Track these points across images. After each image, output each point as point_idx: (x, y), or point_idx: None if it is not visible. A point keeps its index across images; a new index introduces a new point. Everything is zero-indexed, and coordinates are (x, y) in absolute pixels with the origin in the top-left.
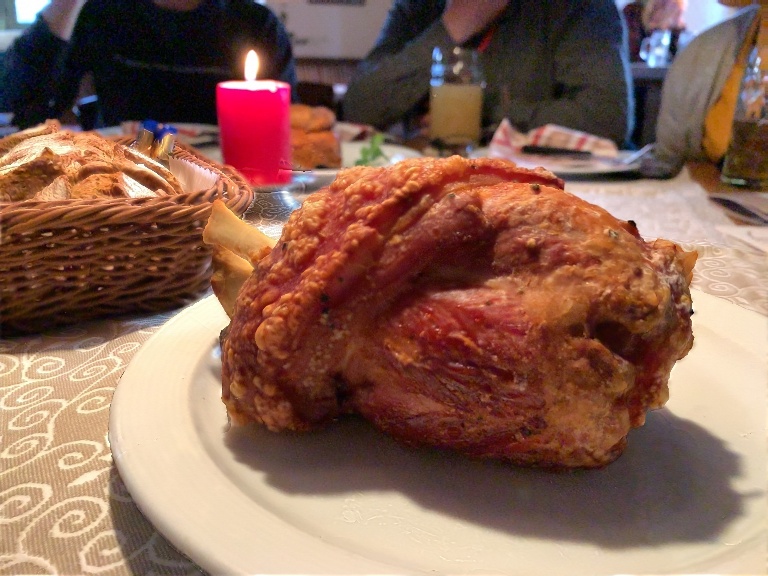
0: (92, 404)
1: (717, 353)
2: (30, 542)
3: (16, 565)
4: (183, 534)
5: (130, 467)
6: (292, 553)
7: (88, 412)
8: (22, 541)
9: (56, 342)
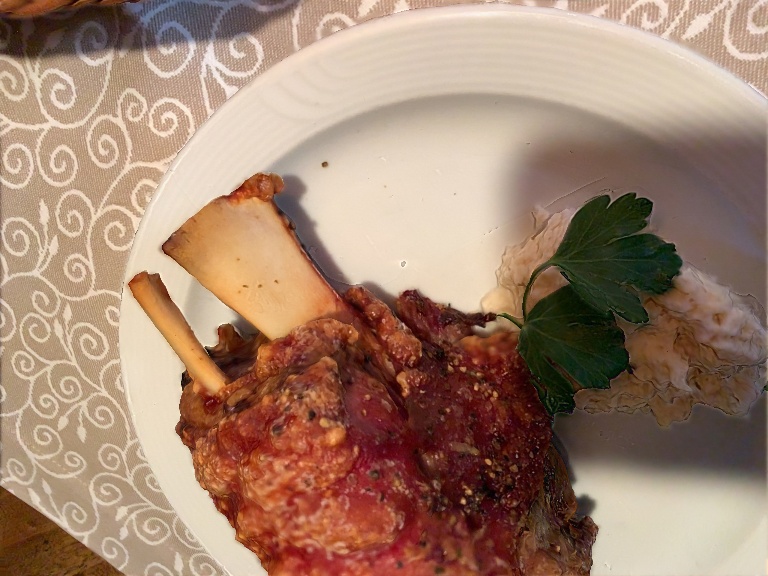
0: (115, 236)
1: (737, 504)
2: (107, 385)
3: (104, 397)
4: (169, 500)
5: (139, 435)
6: (222, 529)
7: (114, 249)
8: (102, 381)
9: (51, 33)
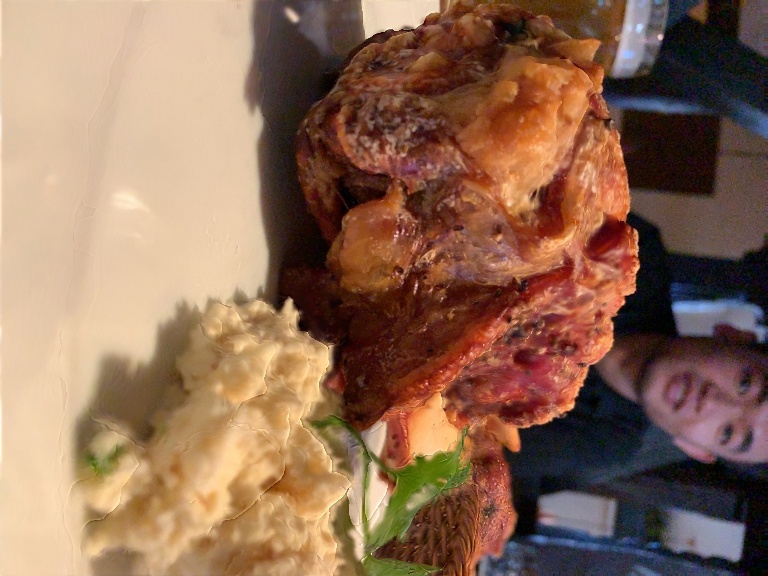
0: None
1: None
2: None
3: None
4: None
5: None
6: None
7: None
8: None
9: None
